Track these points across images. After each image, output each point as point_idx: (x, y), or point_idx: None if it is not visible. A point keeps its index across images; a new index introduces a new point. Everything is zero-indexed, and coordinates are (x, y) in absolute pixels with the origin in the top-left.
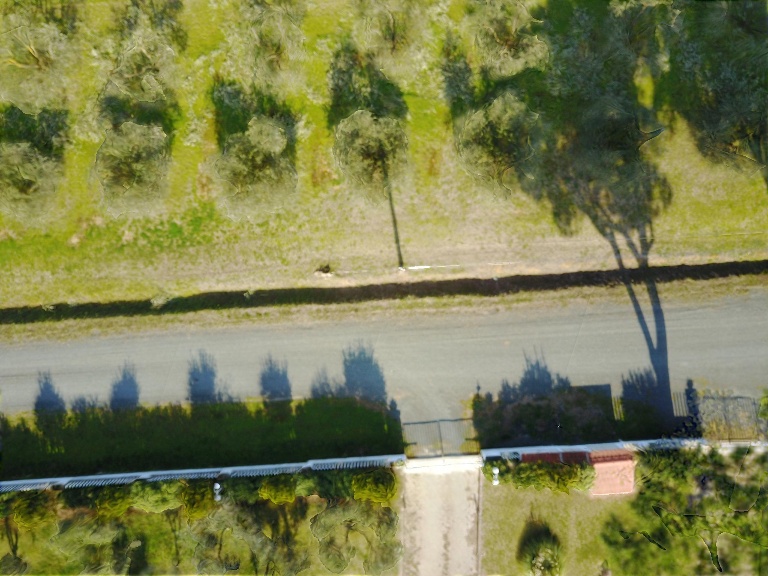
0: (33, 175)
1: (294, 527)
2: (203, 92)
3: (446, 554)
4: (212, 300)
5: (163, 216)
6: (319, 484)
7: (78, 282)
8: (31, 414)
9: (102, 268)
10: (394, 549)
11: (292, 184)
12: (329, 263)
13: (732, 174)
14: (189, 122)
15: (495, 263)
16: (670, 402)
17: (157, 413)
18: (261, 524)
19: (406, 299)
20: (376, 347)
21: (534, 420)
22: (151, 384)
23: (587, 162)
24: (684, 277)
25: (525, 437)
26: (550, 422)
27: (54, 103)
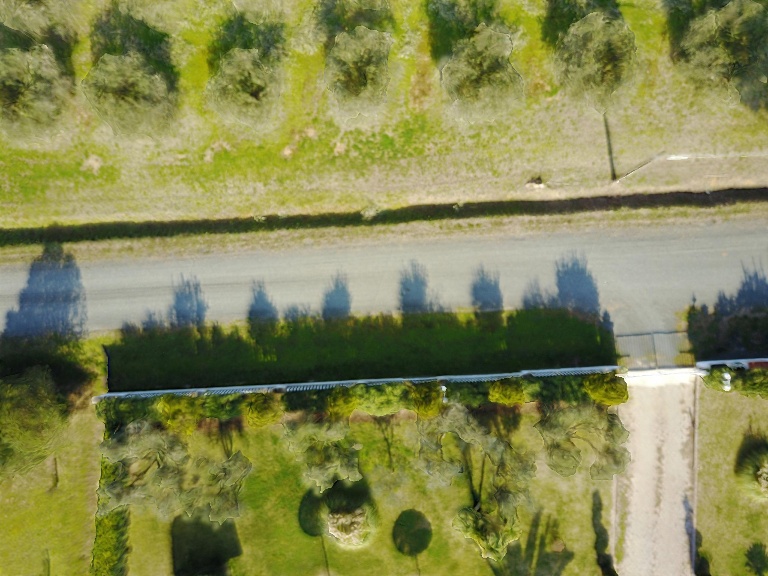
0: (264, 80)
1: (508, 437)
2: (417, 5)
3: (661, 467)
4: (420, 213)
5: (375, 128)
6: (545, 389)
7: (290, 193)
8: (245, 322)
9: (314, 179)
10: (625, 453)
11: (520, 88)
12: (540, 175)
13: None
14: (403, 34)
15: None
16: None
17: (368, 323)
18: None
19: (620, 211)
20: (590, 258)
21: (751, 334)
22: (363, 294)
23: None
24: None
25: (741, 351)
26: (767, 336)
27: (272, 15)
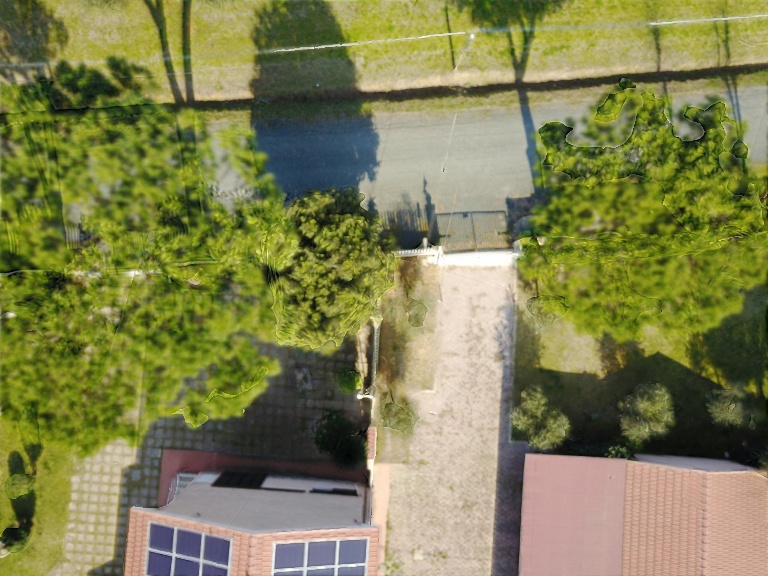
0: None
1: None
2: None
3: None
4: None
5: None
6: None
7: None
8: None
9: None
10: None
11: None
12: None
13: (125, 19)
14: None
15: None
16: (64, 236)
17: None
18: None
19: None
20: None
21: None
22: None
23: None
24: (81, 117)
25: None
26: None
27: None
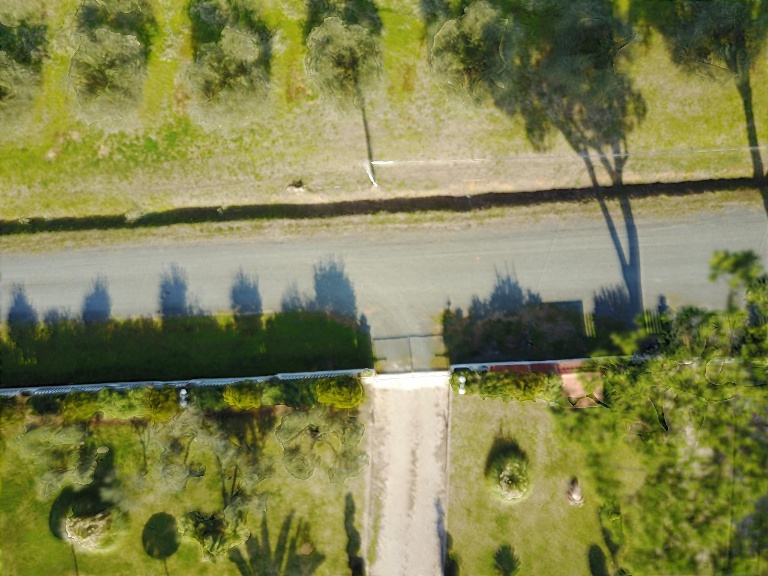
0: (9, 82)
1: (262, 440)
2: (179, 8)
3: (415, 470)
4: (186, 215)
5: (138, 131)
6: (285, 392)
7: (54, 196)
8: (5, 324)
9: (78, 182)
10: (359, 456)
11: (263, 92)
12: (302, 178)
13: (708, 90)
14: (165, 37)
15: (459, 160)
16: (643, 319)
17: (129, 325)
18: (229, 436)
19: (378, 214)
20: (347, 262)
21: (505, 337)
22: (123, 296)
23: (560, 76)
24: (658, 194)
25: (496, 354)
26: (521, 339)
27: (33, 17)
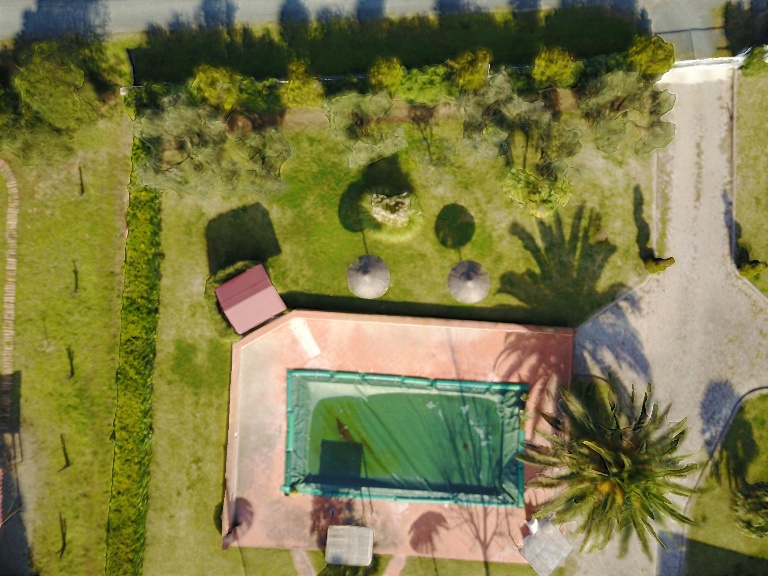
0: None
1: None
2: None
3: (700, 163)
4: None
5: None
6: (589, 66)
7: None
8: (276, 24)
9: None
10: (671, 123)
11: None
12: None
13: None
14: None
15: None
16: None
17: (404, 24)
18: (515, 130)
19: None
20: None
21: None
22: None
23: None
24: None
25: None
26: None
27: None
